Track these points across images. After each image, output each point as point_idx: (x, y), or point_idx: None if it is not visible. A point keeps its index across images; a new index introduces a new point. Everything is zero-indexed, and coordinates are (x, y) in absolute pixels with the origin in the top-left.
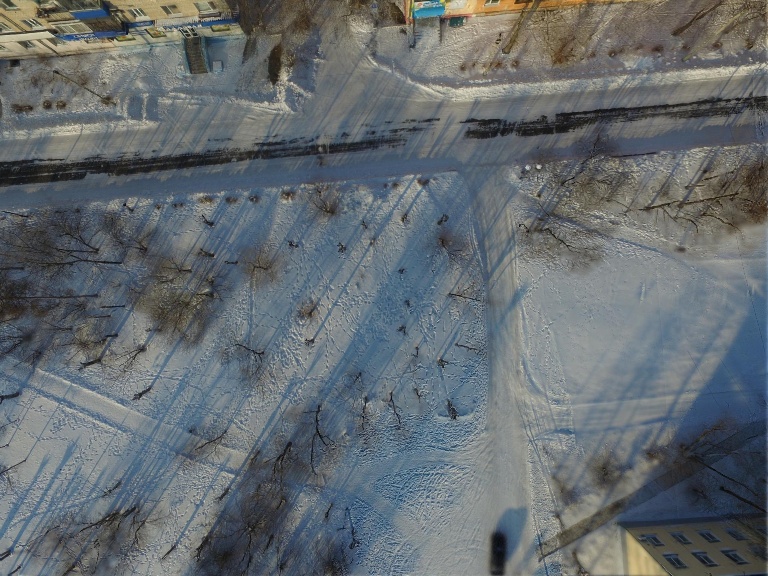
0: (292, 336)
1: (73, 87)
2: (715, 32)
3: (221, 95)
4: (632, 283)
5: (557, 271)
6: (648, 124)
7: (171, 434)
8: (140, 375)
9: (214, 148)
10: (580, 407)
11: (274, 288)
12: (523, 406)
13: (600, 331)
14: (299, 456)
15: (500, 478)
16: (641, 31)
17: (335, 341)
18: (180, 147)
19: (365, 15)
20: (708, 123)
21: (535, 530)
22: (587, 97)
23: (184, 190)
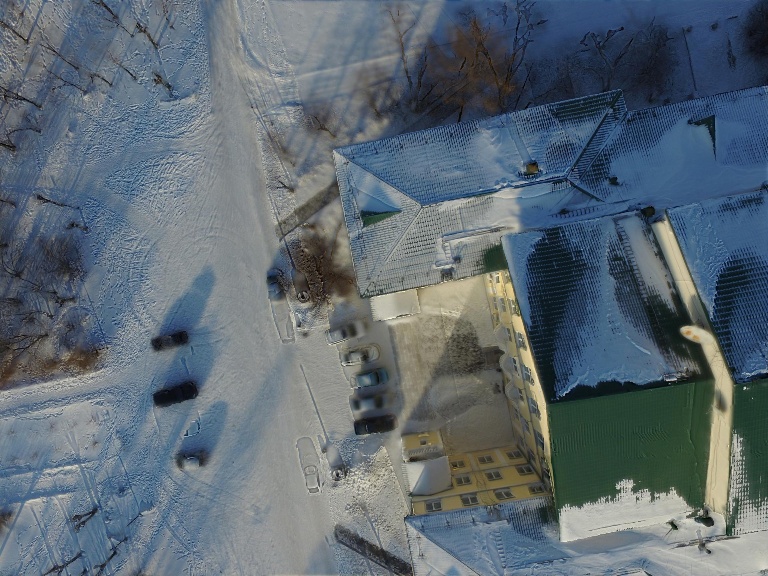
0: (6, 39)
1: None
2: None
3: None
4: None
5: None
6: None
7: None
8: None
9: None
10: (305, 77)
11: None
12: (247, 84)
13: None
14: (24, 159)
15: (232, 161)
16: None
17: (49, 39)
18: None
19: None
20: None
21: (272, 209)
22: None
23: None
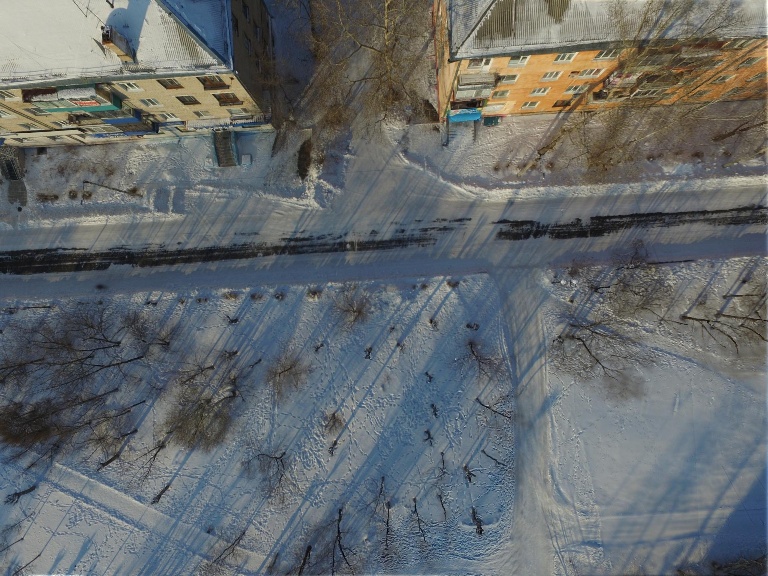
0: (314, 437)
1: (100, 177)
2: (757, 139)
3: (249, 189)
4: (666, 394)
5: (588, 379)
6: (686, 230)
7: (188, 533)
8: (159, 472)
9: (240, 242)
10: (609, 519)
11: (297, 387)
12: (550, 516)
13: (631, 442)
14: (318, 561)
15: None
16: (681, 135)
17: (358, 443)
18: (206, 240)
19: (398, 112)
20: (748, 231)
21: None
22: (623, 201)
23: (209, 284)
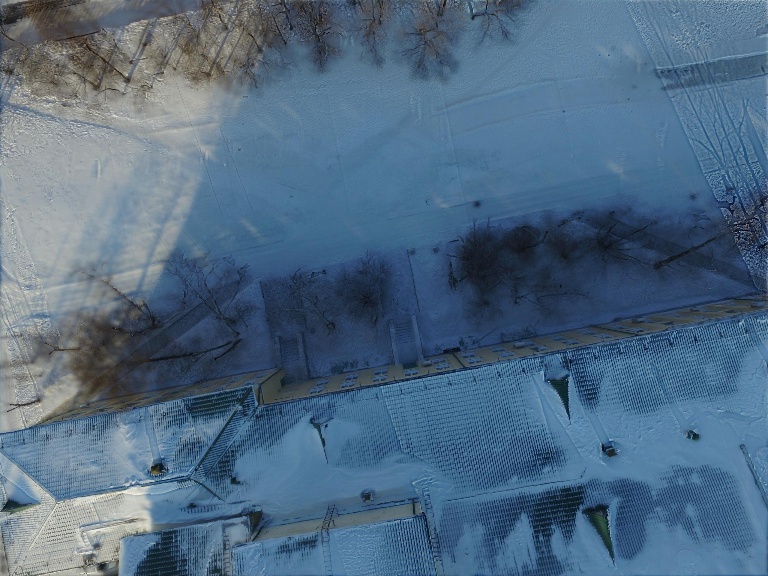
0: None
1: None
2: None
3: None
4: (88, 162)
5: (15, 158)
6: (92, 5)
7: None
8: None
9: None
10: (53, 290)
11: None
12: None
13: (61, 212)
14: None
15: None
16: None
17: None
18: None
19: None
20: None
21: (20, 417)
22: None
23: None
